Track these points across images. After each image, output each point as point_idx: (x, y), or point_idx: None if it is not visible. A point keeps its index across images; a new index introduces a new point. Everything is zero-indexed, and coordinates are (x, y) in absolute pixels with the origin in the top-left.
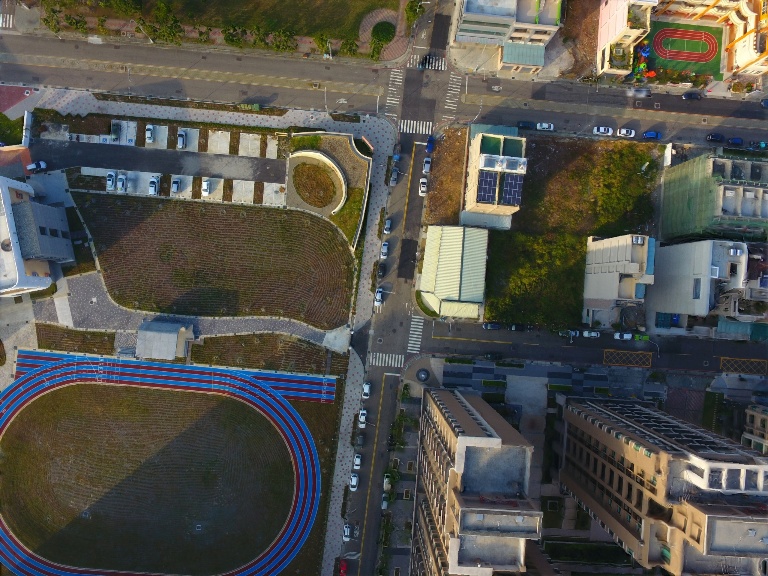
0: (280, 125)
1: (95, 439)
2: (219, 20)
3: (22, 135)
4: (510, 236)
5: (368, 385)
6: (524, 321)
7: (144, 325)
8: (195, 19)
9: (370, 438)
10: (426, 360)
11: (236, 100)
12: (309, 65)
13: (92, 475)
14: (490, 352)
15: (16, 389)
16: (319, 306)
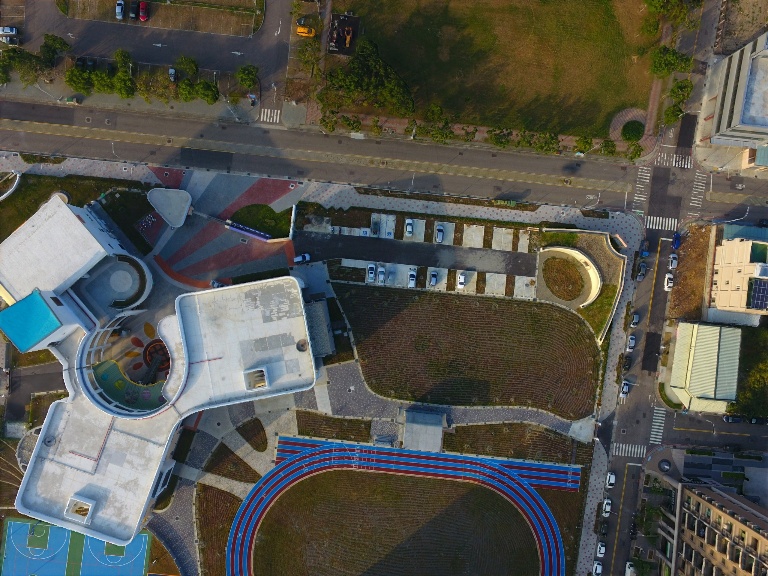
0: (532, 220)
1: (349, 523)
2: (476, 117)
3: (288, 228)
4: (752, 331)
5: (614, 475)
6: (764, 415)
7: (409, 417)
8: (453, 116)
9: (612, 526)
10: (667, 451)
11: (491, 195)
12: (561, 162)
13: (346, 559)
14: (729, 444)
15: (276, 474)
16: (566, 397)
